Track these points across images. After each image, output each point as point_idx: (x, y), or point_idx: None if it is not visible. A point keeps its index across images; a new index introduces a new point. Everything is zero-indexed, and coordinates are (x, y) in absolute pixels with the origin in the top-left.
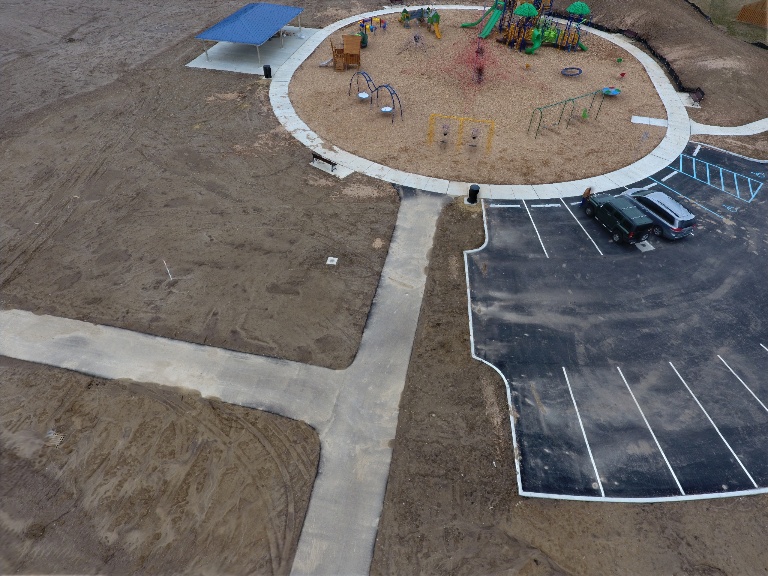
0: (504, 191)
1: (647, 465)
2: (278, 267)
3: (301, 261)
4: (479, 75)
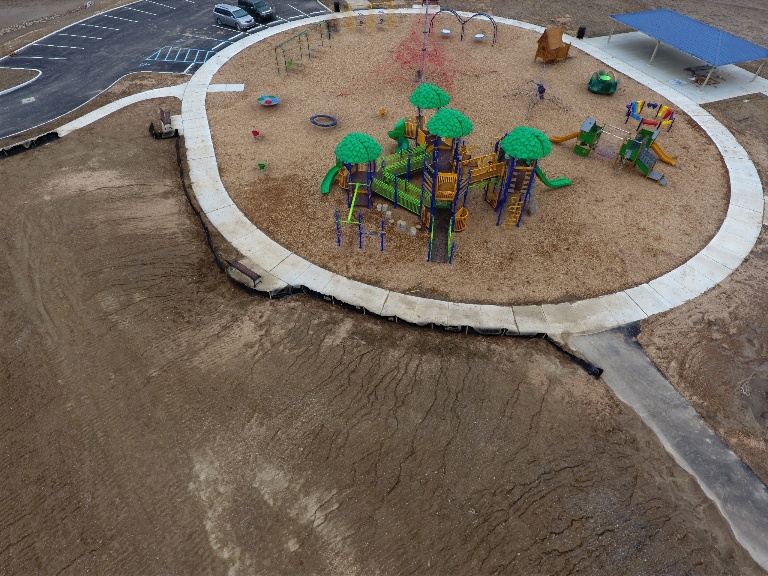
0: (323, 18)
1: None
2: None
3: None
4: None
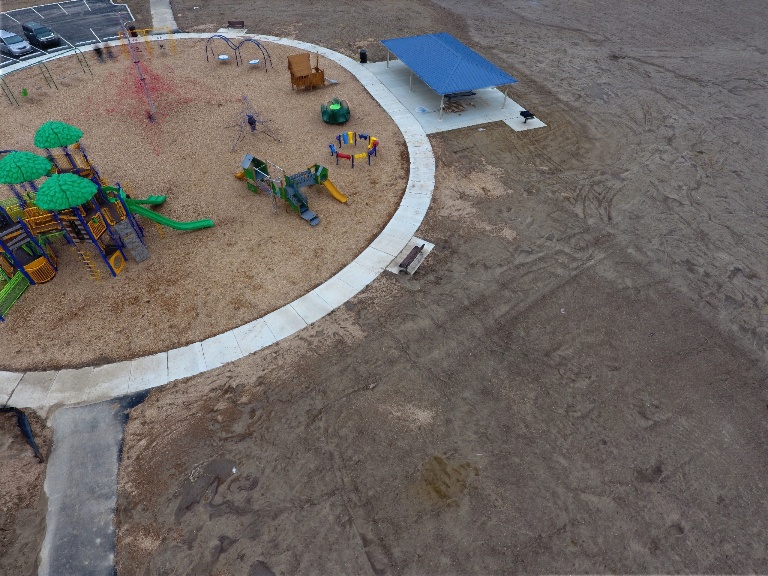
0: (114, 43)
1: (67, 4)
2: (217, 2)
3: (209, 5)
4: (149, 123)
